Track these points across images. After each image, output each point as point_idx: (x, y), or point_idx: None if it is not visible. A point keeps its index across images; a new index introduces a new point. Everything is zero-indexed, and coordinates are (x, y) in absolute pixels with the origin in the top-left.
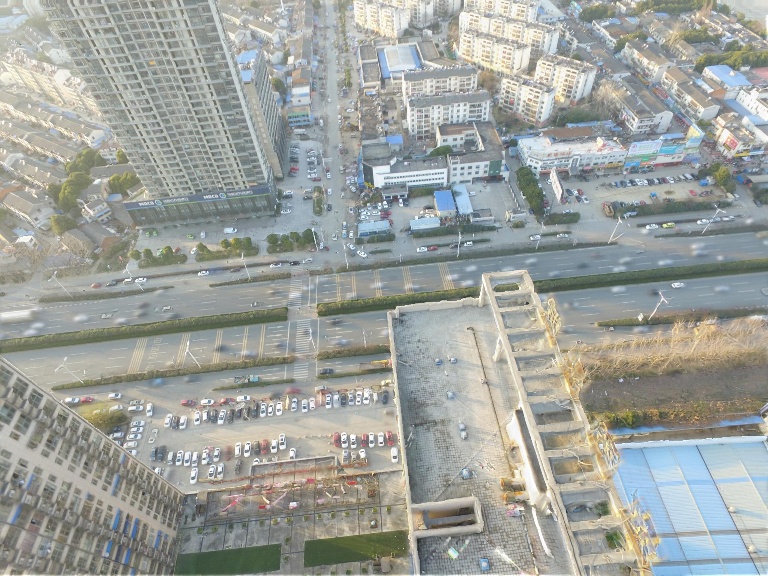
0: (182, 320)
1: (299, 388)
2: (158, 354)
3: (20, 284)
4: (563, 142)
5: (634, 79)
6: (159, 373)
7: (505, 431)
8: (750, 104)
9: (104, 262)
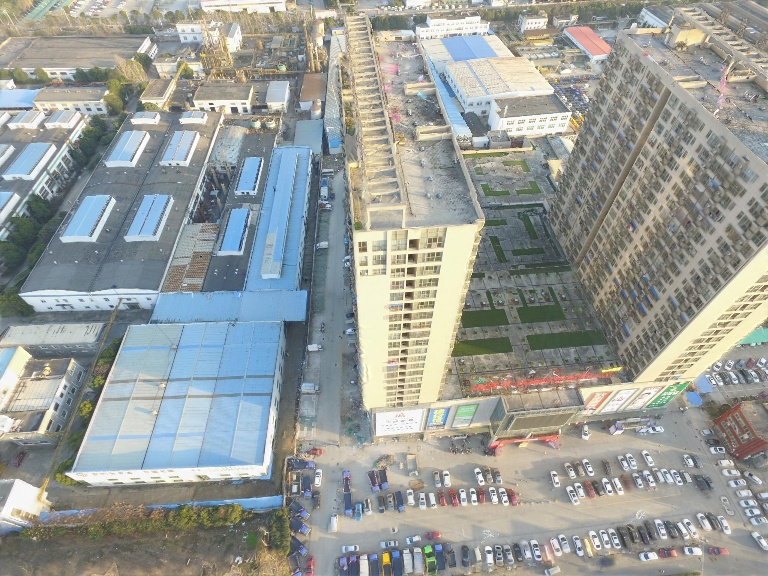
0: None
1: (582, 574)
2: None
3: None
4: None
5: None
6: None
7: (398, 162)
8: None
9: None
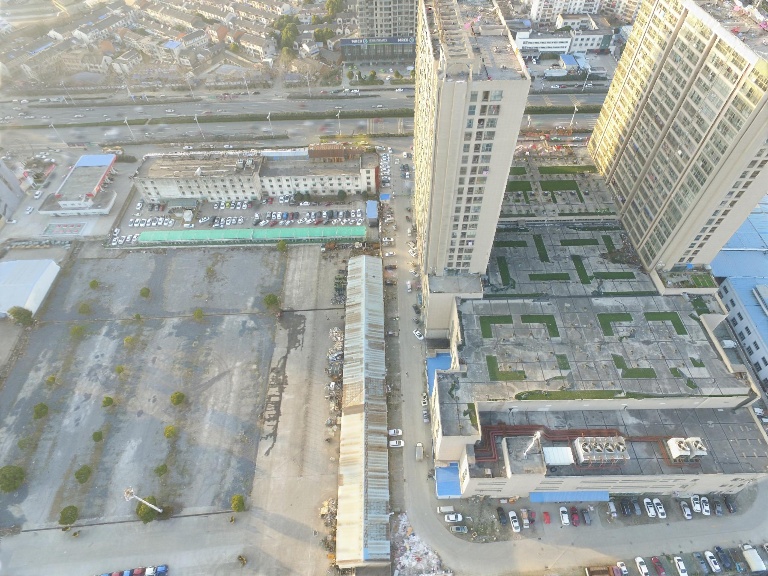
0: (397, 109)
1: None
2: (384, 126)
3: (267, 89)
4: None
5: None
6: (390, 134)
7: None
8: None
9: (324, 81)
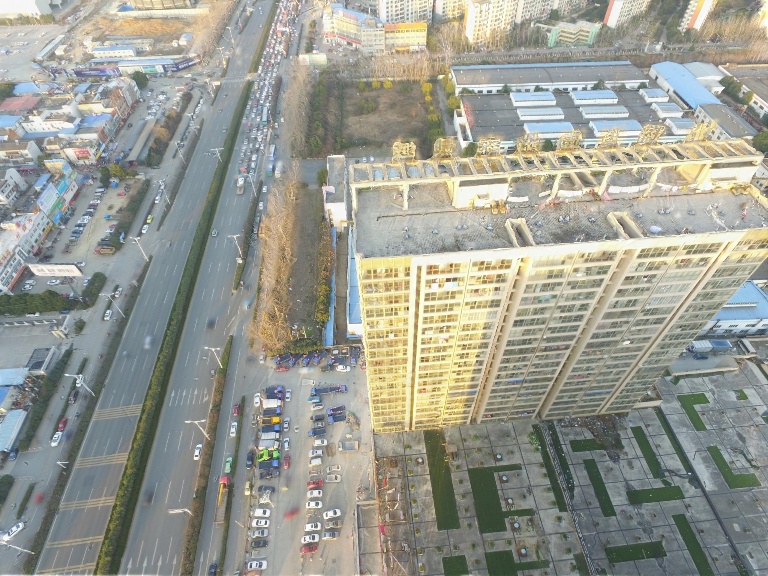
0: None
1: None
2: None
3: None
4: None
5: None
6: None
7: (460, 209)
8: (43, 127)
9: None
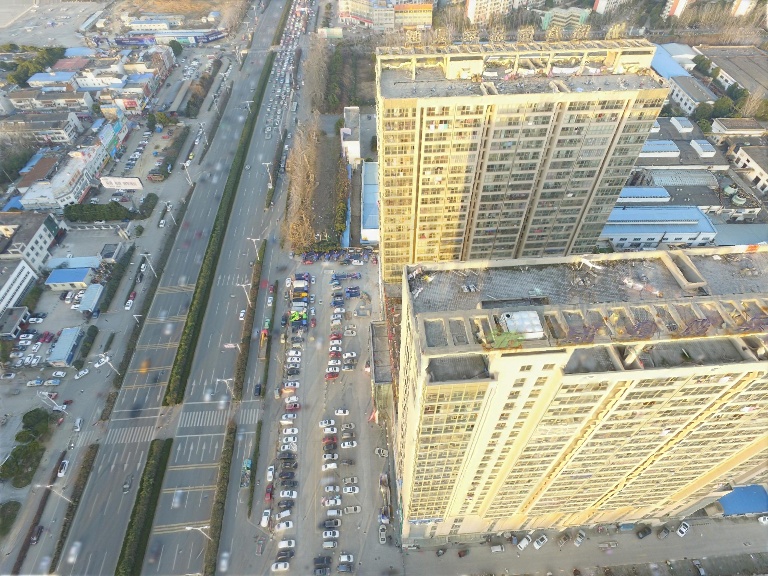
0: None
1: (271, 415)
2: None
3: None
4: (54, 175)
5: (1, 116)
6: None
7: None
8: (95, 83)
9: None
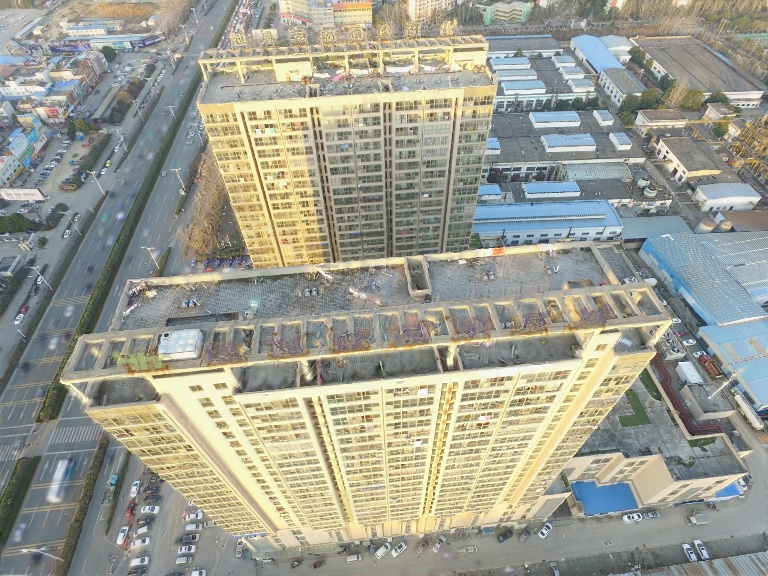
0: None
1: None
2: None
3: None
4: None
5: None
6: None
7: None
8: (18, 92)
9: None
